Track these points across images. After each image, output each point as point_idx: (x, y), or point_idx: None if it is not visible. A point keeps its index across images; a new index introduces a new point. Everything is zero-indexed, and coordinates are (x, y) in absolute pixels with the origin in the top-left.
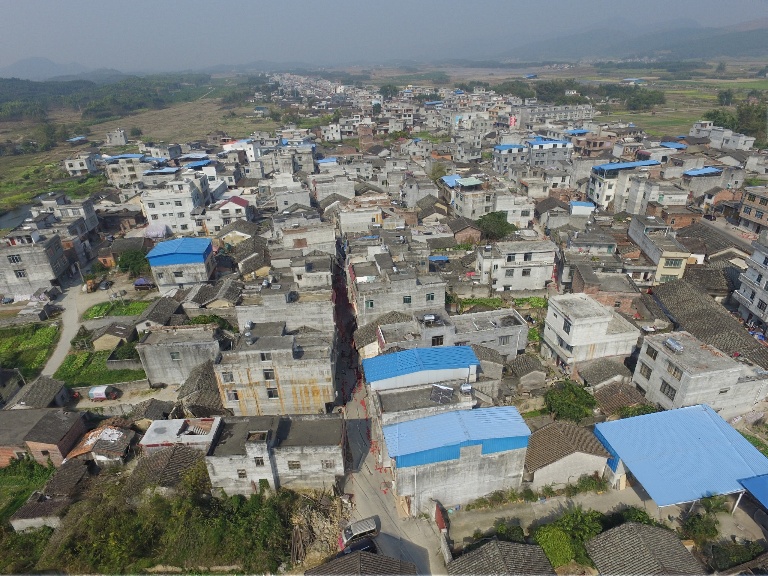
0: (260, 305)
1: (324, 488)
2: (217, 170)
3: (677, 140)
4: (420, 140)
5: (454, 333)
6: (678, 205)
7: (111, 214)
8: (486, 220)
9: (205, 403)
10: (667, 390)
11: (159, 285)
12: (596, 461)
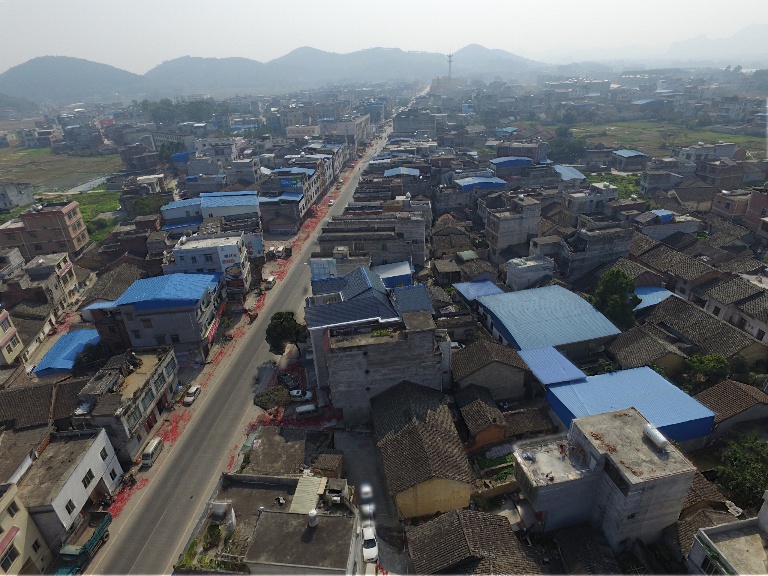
0: None
1: None
2: None
3: None
4: None
5: None
6: None
7: None
8: None
9: None
10: None
11: None
12: None
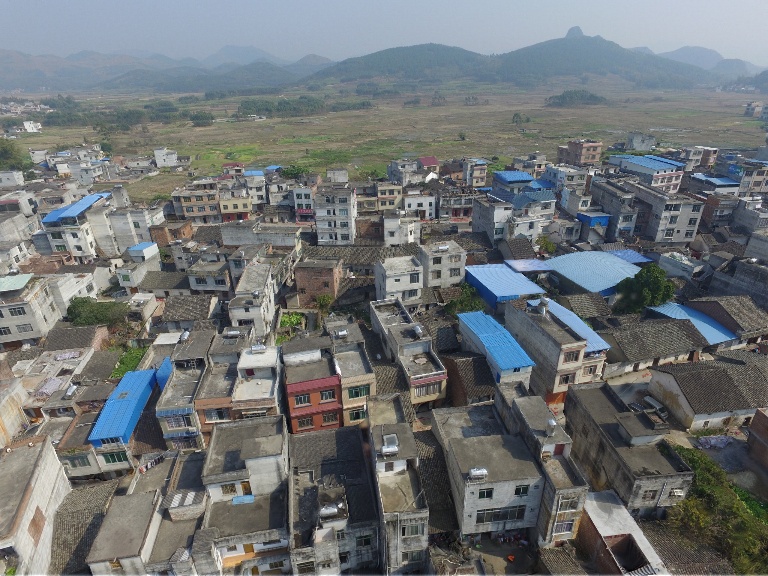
0: None
1: None
2: None
3: None
4: None
5: None
6: (162, 222)
7: None
8: (90, 313)
9: (578, 570)
10: (453, 273)
11: None
12: None
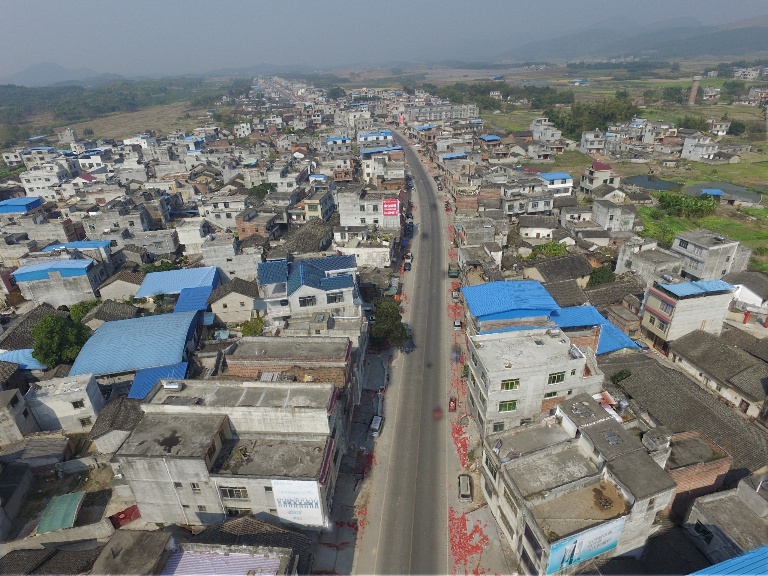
0: (19, 225)
1: (3, 302)
2: (102, 158)
3: (508, 134)
4: (291, 135)
5: (122, 239)
6: (399, 178)
7: (7, 189)
8: (253, 188)
9: None
10: None
11: (0, 227)
12: (134, 287)
